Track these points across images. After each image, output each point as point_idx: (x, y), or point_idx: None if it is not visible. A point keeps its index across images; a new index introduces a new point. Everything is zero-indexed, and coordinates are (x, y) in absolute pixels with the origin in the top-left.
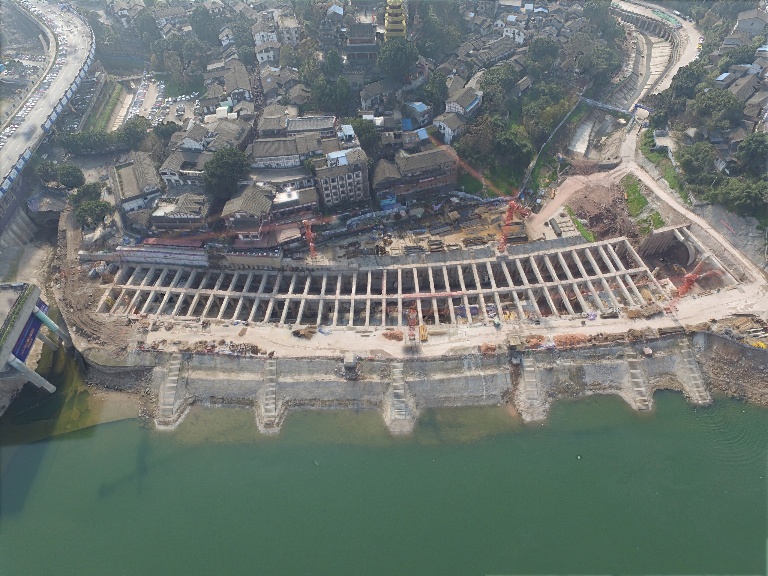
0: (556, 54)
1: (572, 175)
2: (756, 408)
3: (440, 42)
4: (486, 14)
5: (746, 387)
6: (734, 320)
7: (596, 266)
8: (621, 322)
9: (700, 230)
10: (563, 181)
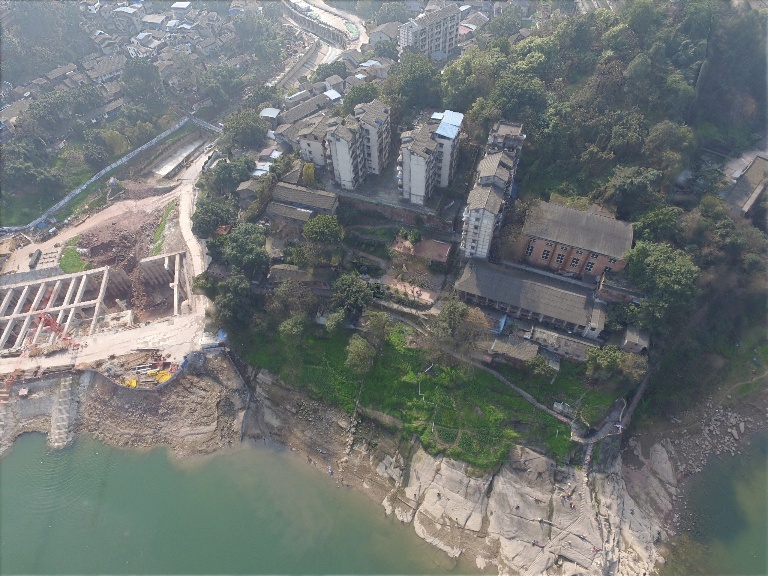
0: (153, 73)
1: (123, 200)
2: (110, 449)
3: (24, 64)
4: (126, 31)
5: (111, 427)
6: (133, 356)
7: (50, 300)
8: (17, 361)
9: (188, 258)
10: (107, 207)
